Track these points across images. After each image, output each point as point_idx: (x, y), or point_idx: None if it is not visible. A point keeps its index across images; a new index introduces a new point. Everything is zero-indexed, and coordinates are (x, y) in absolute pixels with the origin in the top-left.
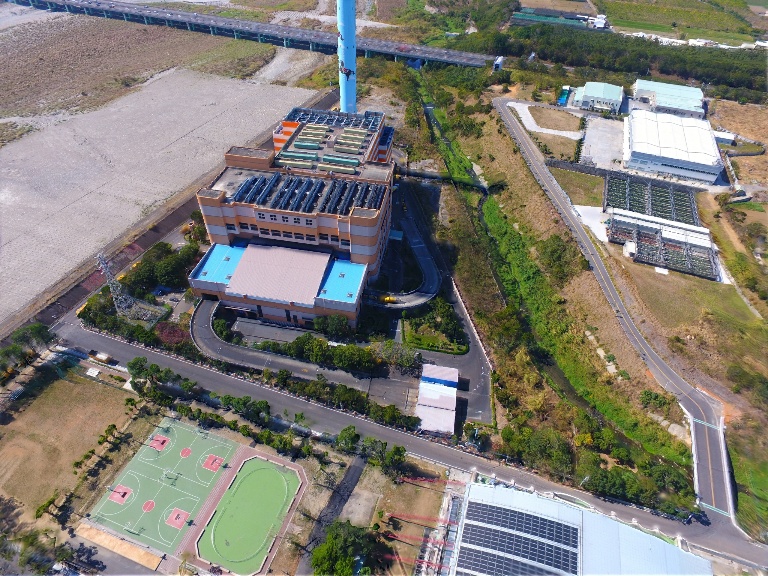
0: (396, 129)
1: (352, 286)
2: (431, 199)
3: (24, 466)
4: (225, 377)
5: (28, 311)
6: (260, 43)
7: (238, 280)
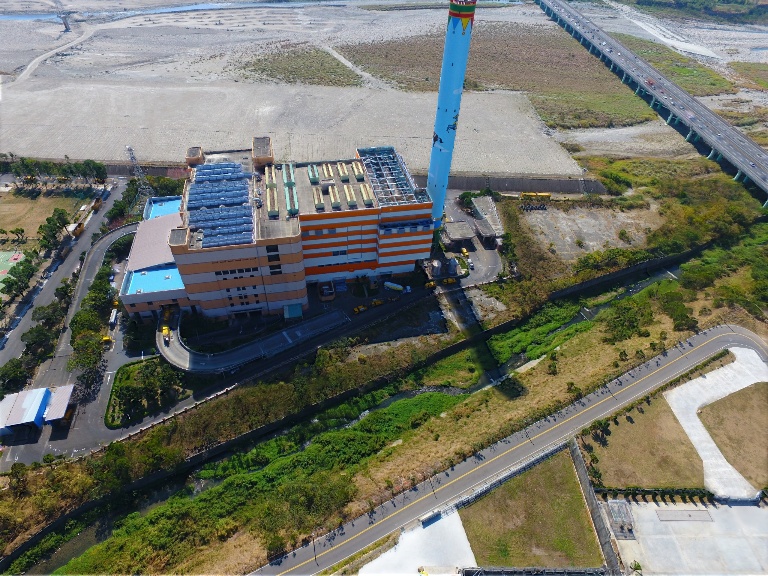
0: (554, 255)
1: (153, 289)
2: (404, 329)
3: (9, 215)
4: (77, 265)
5: (141, 163)
6: (648, 108)
7: (152, 222)
